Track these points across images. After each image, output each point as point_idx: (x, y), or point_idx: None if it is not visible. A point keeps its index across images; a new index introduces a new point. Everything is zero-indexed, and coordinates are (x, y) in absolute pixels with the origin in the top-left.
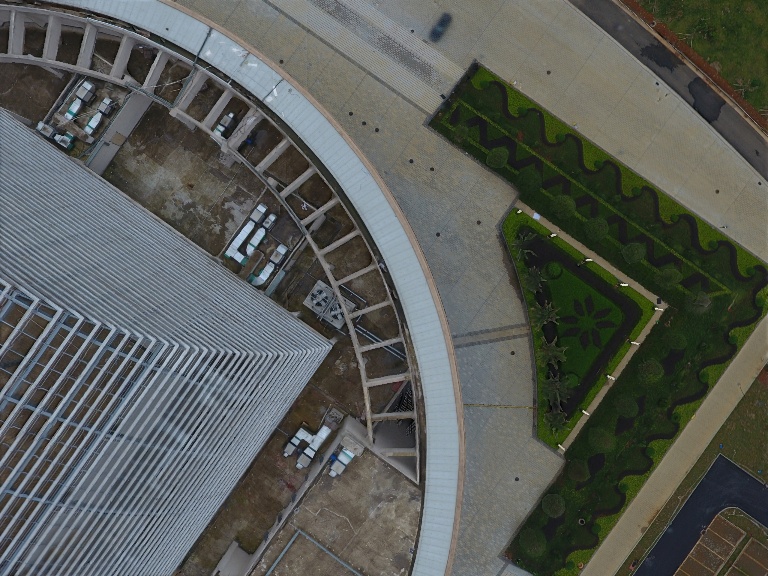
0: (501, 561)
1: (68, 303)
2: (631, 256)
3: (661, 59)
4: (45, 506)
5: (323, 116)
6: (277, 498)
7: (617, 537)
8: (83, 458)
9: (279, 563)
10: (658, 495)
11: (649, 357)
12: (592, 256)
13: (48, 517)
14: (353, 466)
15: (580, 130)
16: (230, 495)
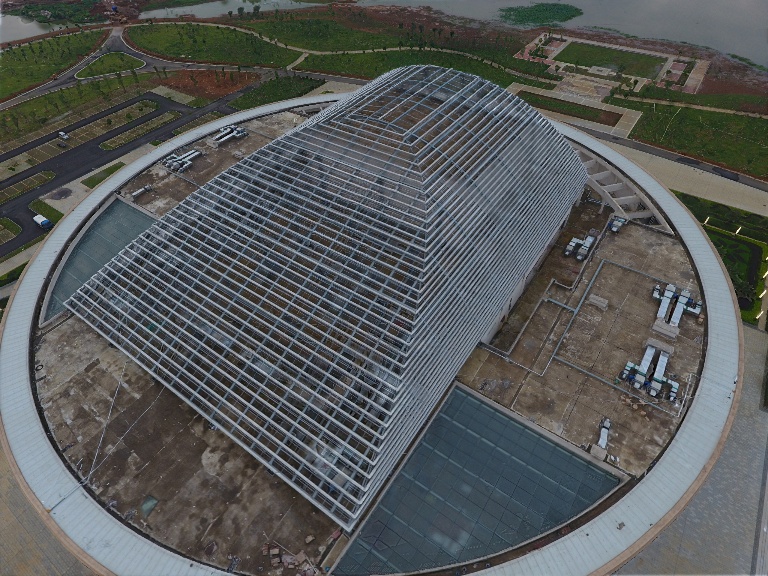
0: (765, 413)
1: None
2: (733, 214)
3: (690, 162)
4: None
5: None
6: (568, 279)
7: None
8: (506, 139)
9: (596, 279)
10: None
11: None
12: None
13: (492, 158)
14: (625, 231)
15: None
16: (532, 279)
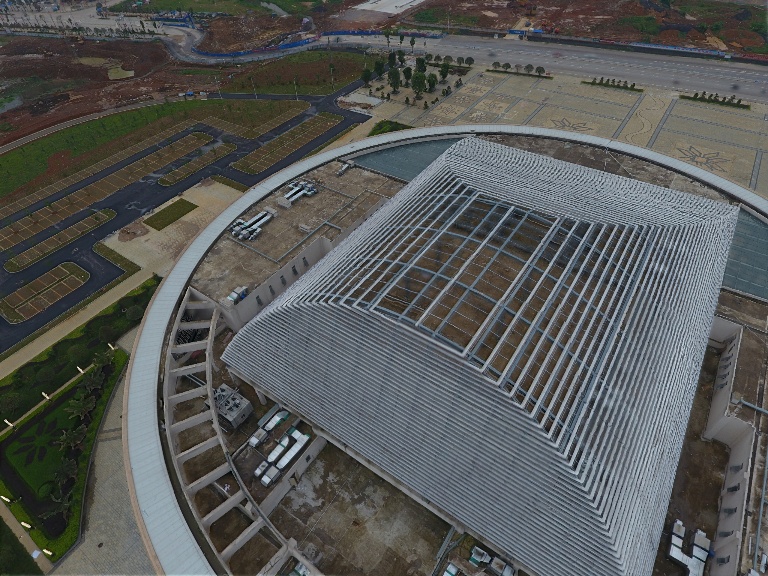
0: None
1: (342, 312)
2: None
3: None
4: None
5: None
6: None
7: (105, 304)
8: None
9: None
10: (62, 328)
11: (7, 417)
12: (3, 510)
13: None
14: None
15: None
16: None
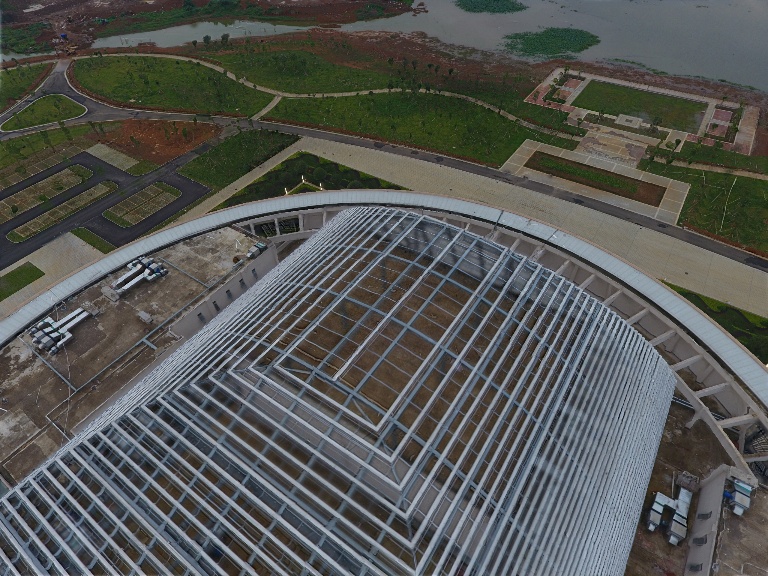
0: None
1: None
2: None
3: (763, 264)
4: (540, 428)
5: (593, 246)
6: None
7: None
8: (562, 387)
9: None
10: None
11: None
12: None
13: (542, 443)
14: (752, 508)
15: (733, 305)
16: None
